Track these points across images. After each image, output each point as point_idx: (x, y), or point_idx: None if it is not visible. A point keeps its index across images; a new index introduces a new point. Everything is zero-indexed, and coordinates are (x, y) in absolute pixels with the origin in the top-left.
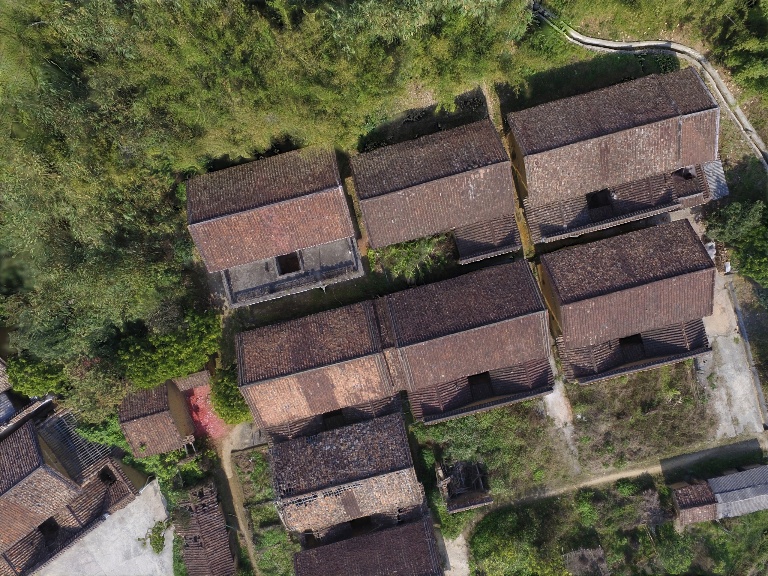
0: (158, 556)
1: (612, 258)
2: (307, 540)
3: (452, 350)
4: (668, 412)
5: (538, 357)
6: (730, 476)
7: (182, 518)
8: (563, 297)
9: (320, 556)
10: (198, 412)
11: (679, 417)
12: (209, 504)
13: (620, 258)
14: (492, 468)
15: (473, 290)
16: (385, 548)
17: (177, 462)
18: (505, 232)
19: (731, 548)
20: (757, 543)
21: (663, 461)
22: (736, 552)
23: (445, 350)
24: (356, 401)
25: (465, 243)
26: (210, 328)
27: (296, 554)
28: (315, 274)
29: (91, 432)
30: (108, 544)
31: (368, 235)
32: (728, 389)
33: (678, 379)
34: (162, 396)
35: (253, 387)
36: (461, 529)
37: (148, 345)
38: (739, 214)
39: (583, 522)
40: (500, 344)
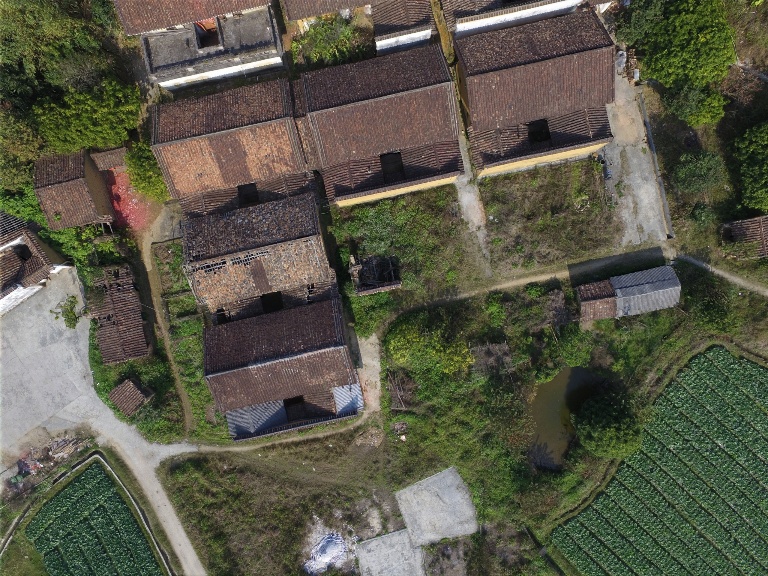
0: (74, 344)
1: (520, 41)
2: (219, 320)
3: (362, 121)
4: (577, 217)
5: (447, 138)
6: (631, 274)
7: (96, 295)
8: (470, 71)
9: (229, 330)
10: (119, 202)
11: (587, 222)
12: (124, 285)
13: (527, 41)
14: (404, 260)
15: (386, 68)
16: (292, 322)
17: (93, 239)
18: (420, 16)
19: (633, 353)
20: (657, 348)
21: (571, 266)
22: (637, 357)
23: (355, 120)
24: (269, 174)
25: (382, 28)
26: (128, 98)
27: (206, 329)
28: (235, 52)
29: (6, 200)
30: (24, 330)
31: (284, 4)
32: (634, 197)
33: (587, 185)
34: (79, 166)
35: (165, 147)
36: (374, 326)
37: (64, 106)
38: (643, 7)
39: (492, 322)
40: (409, 118)
